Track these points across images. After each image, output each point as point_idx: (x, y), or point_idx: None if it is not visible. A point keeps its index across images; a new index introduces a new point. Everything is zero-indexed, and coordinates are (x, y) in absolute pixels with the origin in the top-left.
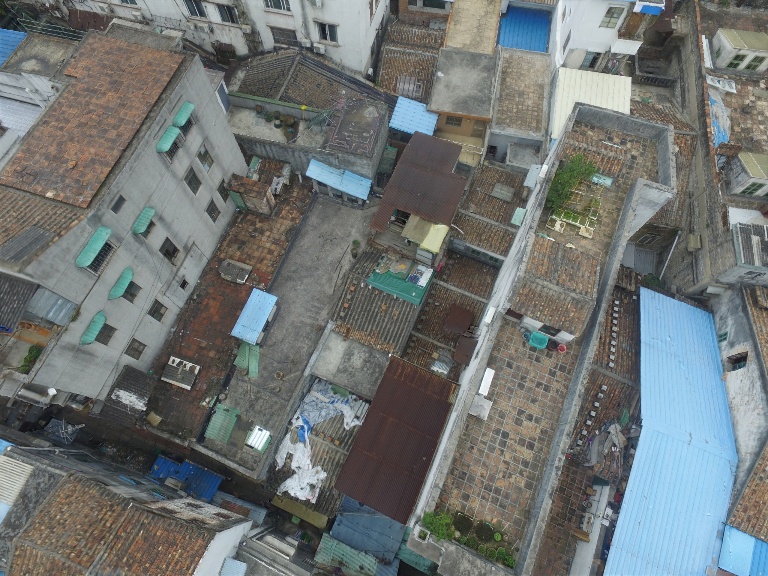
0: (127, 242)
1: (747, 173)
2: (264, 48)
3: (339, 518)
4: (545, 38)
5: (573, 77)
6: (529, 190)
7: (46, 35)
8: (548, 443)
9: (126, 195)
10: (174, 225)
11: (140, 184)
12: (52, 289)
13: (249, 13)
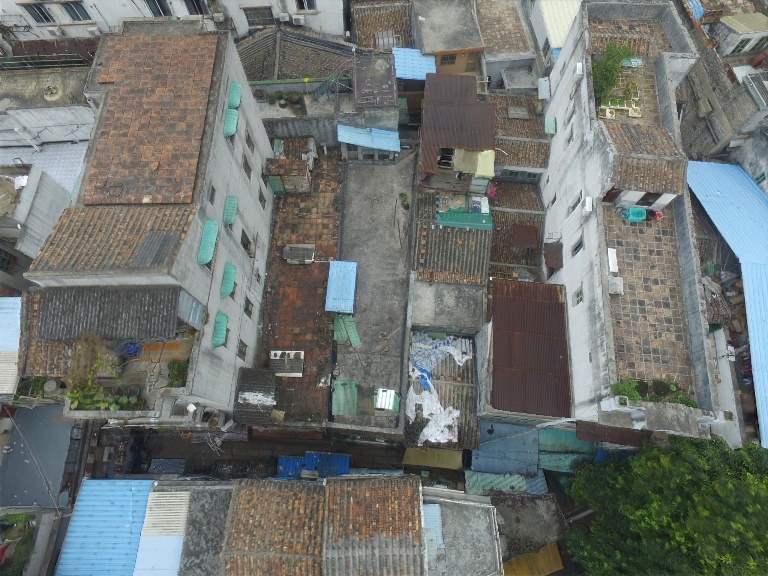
0: (222, 236)
1: (736, 32)
2: (238, 35)
3: (475, 452)
4: None
5: None
6: (542, 104)
7: (9, 70)
8: (680, 298)
9: (215, 185)
10: (244, 215)
11: (220, 172)
12: (189, 291)
13: None
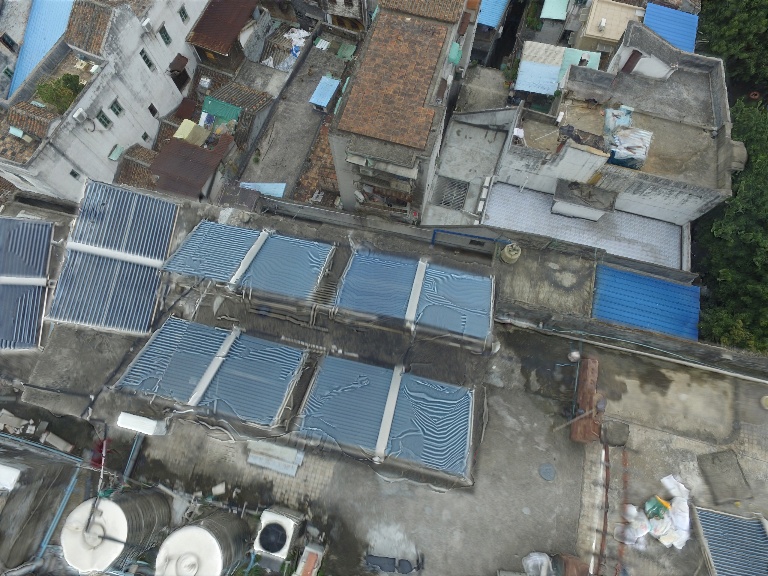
0: None
1: None
2: None
3: None
4: None
5: None
6: None
7: None
8: None
9: None
10: None
11: None
12: None
13: None
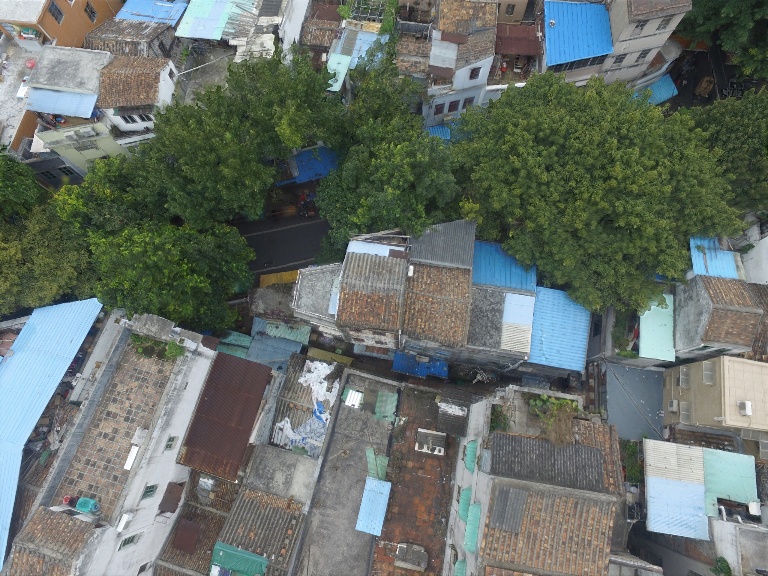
0: None
1: None
2: None
3: None
4: None
5: None
6: None
7: None
8: (95, 418)
9: None
10: None
11: None
12: None
13: None
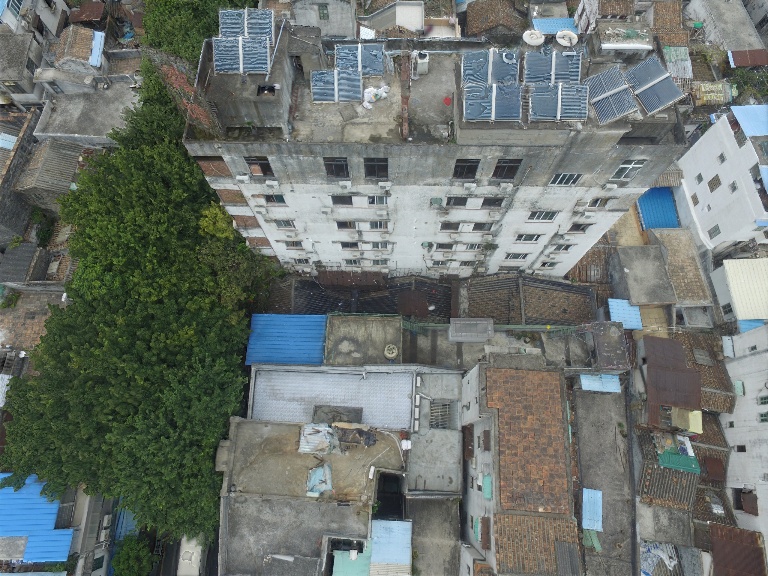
0: None
1: None
2: (486, 274)
3: None
4: (673, 208)
5: (735, 266)
6: None
7: (344, 317)
8: None
9: None
10: None
11: None
12: None
13: (488, 262)
